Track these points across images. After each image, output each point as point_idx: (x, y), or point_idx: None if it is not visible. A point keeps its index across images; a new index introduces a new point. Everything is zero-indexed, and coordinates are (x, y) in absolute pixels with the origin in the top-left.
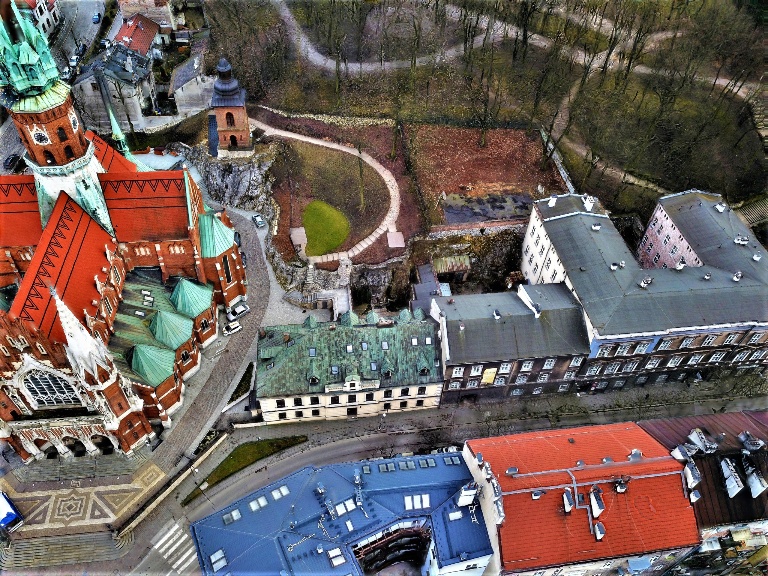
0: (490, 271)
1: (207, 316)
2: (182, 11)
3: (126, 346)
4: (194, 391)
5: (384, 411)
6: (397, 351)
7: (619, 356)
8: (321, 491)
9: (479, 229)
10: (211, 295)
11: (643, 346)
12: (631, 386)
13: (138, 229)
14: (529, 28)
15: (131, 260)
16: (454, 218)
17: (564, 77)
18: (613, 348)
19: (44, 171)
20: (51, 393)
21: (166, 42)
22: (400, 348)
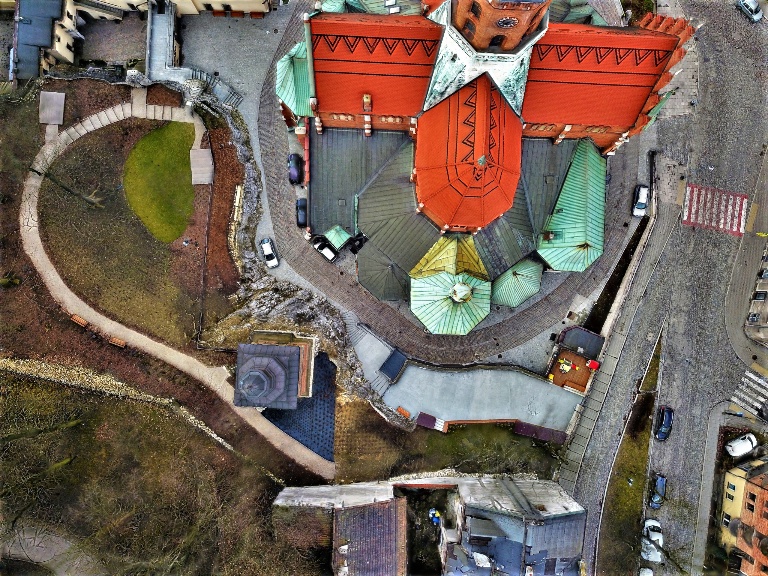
0: None
1: None
2: None
3: None
4: None
5: None
6: None
7: None
8: None
9: None
10: None
11: None
12: None
13: None
14: None
15: None
16: None
17: None
18: None
19: None
20: None
21: None
22: None
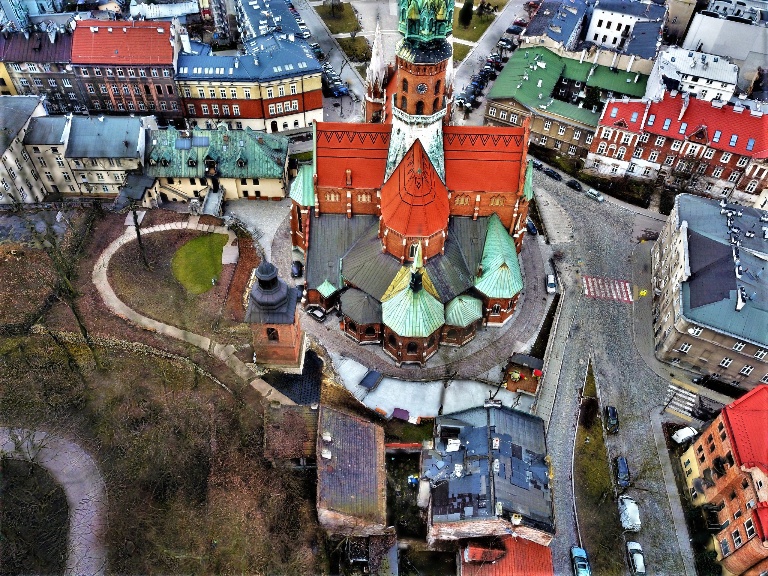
0: None
1: None
2: None
3: None
4: None
5: None
6: None
7: None
8: None
9: None
10: None
11: None
12: None
13: None
14: None
15: None
16: None
17: None
18: None
19: None
20: None
21: None
22: None
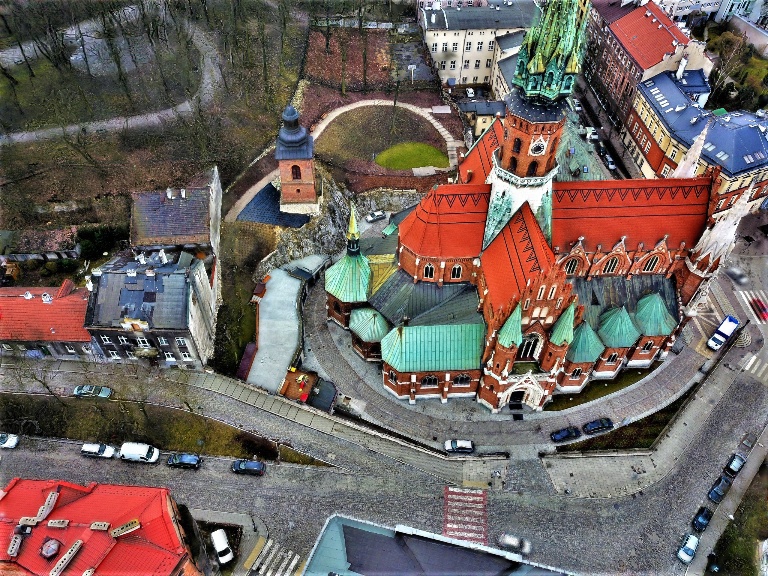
0: None
1: None
2: None
3: None
4: None
5: None
6: None
7: None
8: None
9: None
10: None
11: None
12: None
13: None
14: None
15: None
16: None
17: None
18: None
19: None
20: None
21: None
22: None
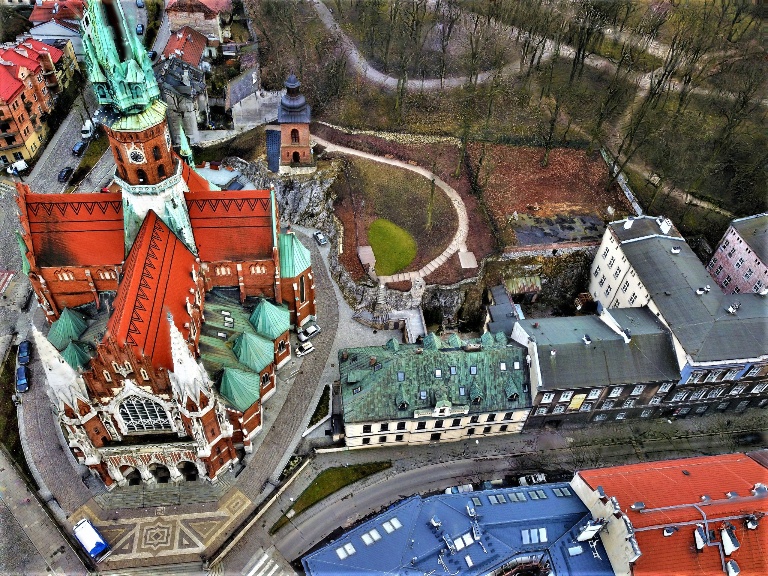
0: (559, 292)
1: (285, 337)
2: (229, 24)
3: (212, 369)
4: (272, 414)
5: (466, 436)
6: (486, 376)
7: (708, 382)
8: (437, 525)
9: (551, 250)
10: (289, 316)
11: (733, 372)
12: (712, 412)
13: (221, 249)
14: (587, 48)
15: (211, 280)
16: (528, 239)
17: (627, 97)
18: (704, 374)
19: (136, 190)
20: (143, 419)
21: (213, 55)
22: (488, 373)
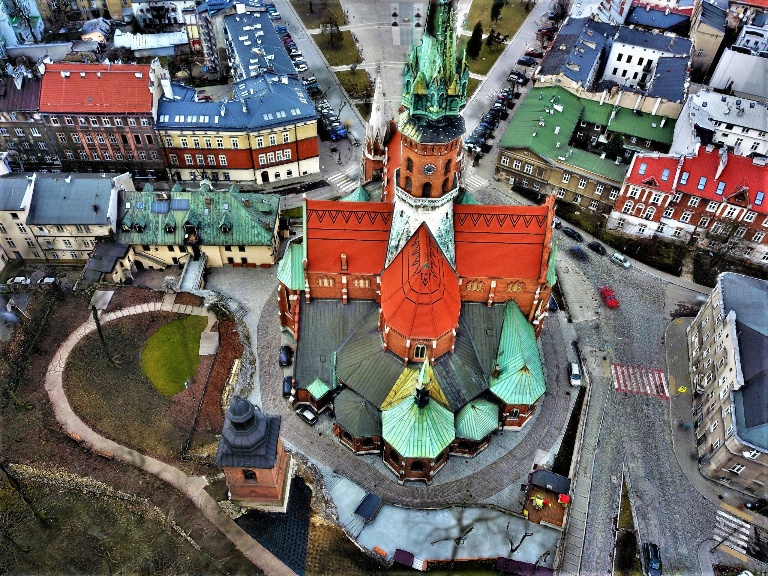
0: None
1: None
2: None
3: (372, 200)
4: None
5: None
6: None
7: None
8: None
9: None
10: None
11: None
12: None
13: None
14: None
15: None
16: None
17: None
18: None
19: None
20: None
21: None
22: None
